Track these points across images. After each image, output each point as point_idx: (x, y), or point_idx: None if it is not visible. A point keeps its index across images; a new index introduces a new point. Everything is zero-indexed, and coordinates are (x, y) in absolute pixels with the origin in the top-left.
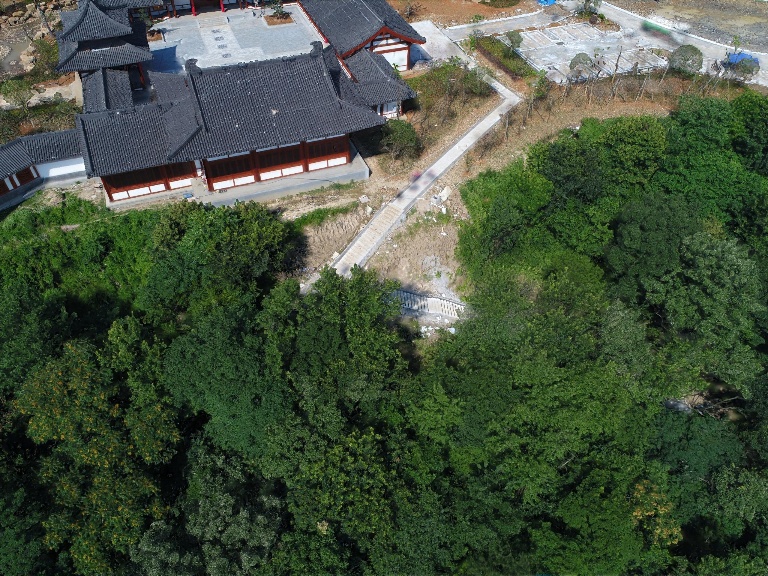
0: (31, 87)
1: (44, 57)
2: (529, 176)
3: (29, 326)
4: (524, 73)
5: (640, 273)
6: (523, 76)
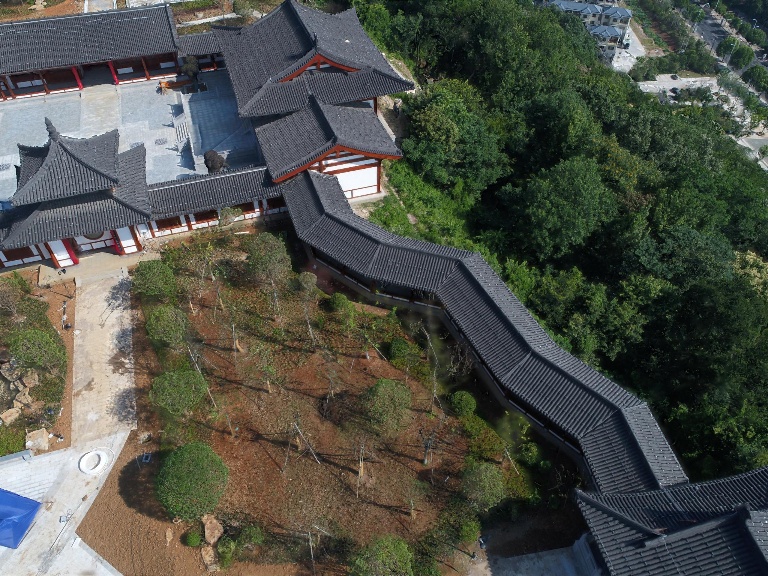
0: (68, 325)
1: (19, 291)
2: (375, 7)
3: (580, 162)
4: (213, 2)
5: (442, 8)
6: (218, 3)
